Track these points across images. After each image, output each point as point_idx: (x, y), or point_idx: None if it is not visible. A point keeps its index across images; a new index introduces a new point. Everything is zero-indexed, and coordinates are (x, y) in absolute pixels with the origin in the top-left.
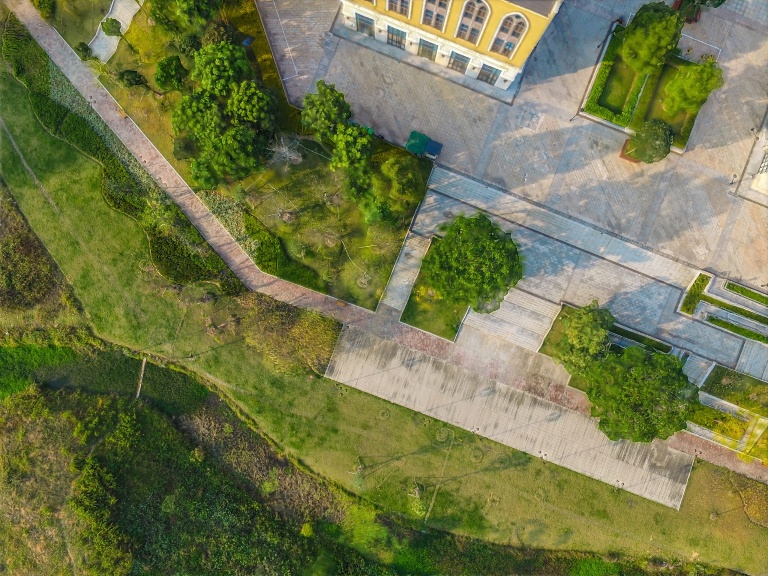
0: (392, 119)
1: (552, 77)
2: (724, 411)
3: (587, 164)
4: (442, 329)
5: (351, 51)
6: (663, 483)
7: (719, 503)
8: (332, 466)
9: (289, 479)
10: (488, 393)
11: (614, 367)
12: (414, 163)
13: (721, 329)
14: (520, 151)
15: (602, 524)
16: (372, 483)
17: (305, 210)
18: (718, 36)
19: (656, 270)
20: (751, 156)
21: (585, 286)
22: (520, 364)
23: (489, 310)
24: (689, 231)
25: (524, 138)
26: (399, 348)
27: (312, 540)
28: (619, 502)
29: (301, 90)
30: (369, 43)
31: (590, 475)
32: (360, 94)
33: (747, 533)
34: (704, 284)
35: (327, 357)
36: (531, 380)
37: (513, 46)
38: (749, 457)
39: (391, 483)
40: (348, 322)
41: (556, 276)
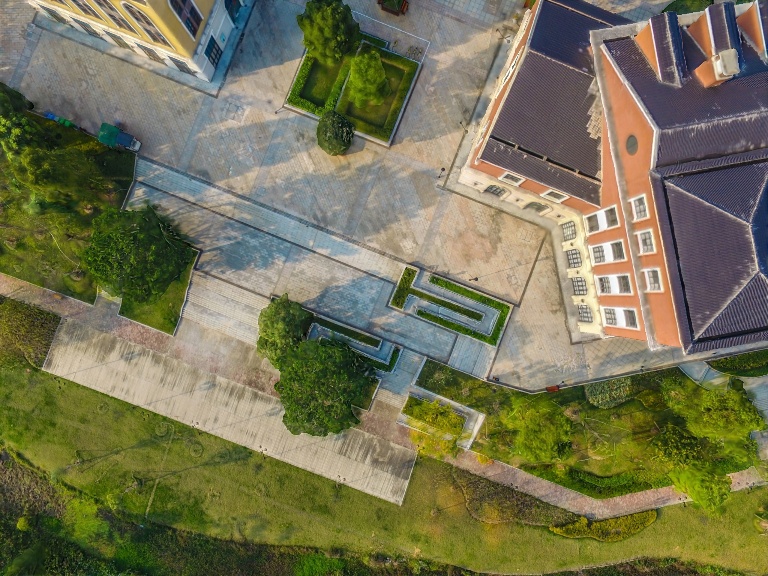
0: (95, 111)
1: (258, 69)
2: (441, 406)
3: (293, 157)
4: (160, 323)
5: (54, 42)
6: (385, 478)
7: (441, 499)
8: (51, 460)
9: (9, 473)
10: (208, 387)
11: (291, 360)
12: (73, 154)
13: (434, 323)
14: (225, 143)
15: (323, 519)
16: (91, 477)
17: (11, 202)
18: (427, 28)
19: (366, 264)
20: (460, 149)
21: (296, 280)
22: (241, 358)
23: (149, 302)
24: (396, 225)
25: (229, 130)
26: (118, 341)
27: (29, 534)
28: (340, 497)
29: (2, 81)
30: (72, 34)
31: (311, 470)
32: (62, 86)
33: (468, 529)
34: (411, 278)
35: (45, 350)
36: (252, 374)
37: (162, 36)
38: (472, 453)
39: (110, 477)
40: (66, 315)
41: (266, 269)
